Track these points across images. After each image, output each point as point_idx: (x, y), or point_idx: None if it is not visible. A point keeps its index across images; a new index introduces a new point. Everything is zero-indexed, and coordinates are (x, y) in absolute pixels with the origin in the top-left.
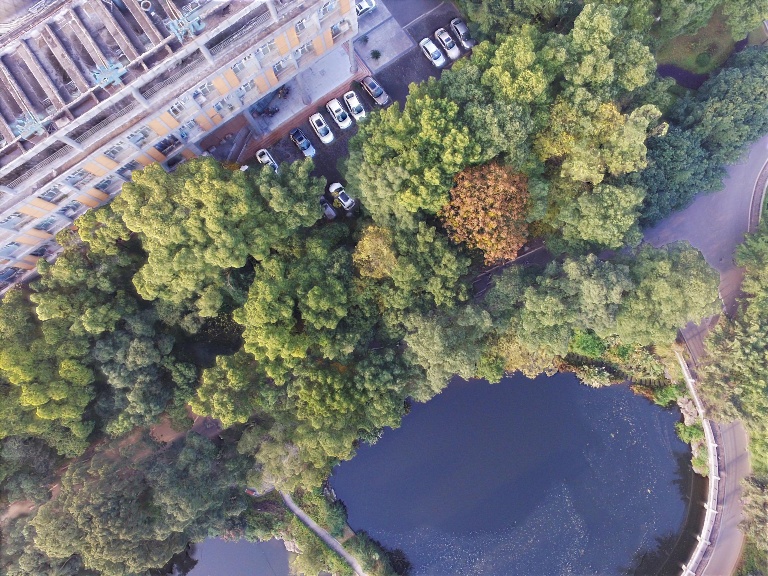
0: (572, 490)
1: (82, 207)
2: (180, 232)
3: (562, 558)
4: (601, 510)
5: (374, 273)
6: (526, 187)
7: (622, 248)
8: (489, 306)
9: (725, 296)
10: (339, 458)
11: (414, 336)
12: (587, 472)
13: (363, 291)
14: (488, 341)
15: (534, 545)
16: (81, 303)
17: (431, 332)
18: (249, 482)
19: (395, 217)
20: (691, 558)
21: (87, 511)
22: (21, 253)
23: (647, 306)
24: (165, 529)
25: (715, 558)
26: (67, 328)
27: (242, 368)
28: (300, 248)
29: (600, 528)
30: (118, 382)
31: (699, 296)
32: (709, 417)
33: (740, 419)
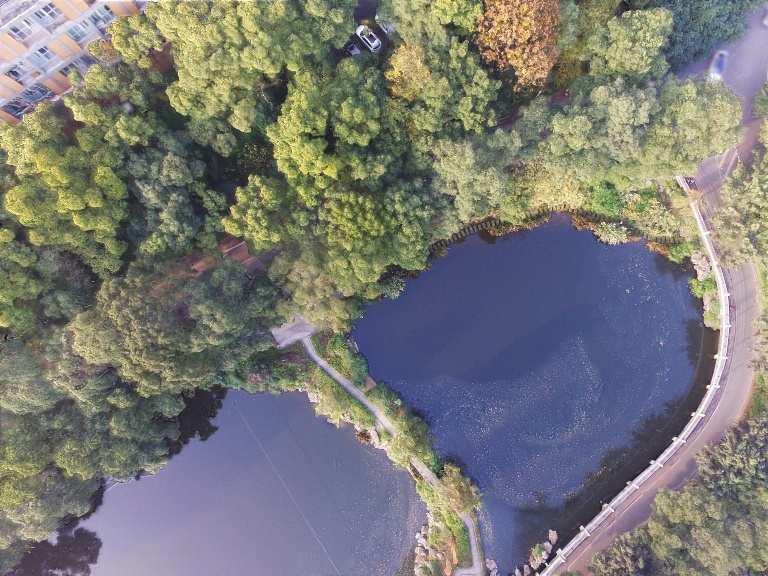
0: (588, 343)
1: (113, 20)
2: (216, 30)
3: (577, 407)
4: (615, 362)
5: (406, 90)
6: (558, 6)
7: (648, 80)
8: None
9: (741, 153)
10: (365, 297)
11: (444, 159)
12: (602, 326)
13: None
14: (514, 173)
15: (550, 395)
16: (114, 116)
17: (462, 149)
18: (280, 309)
19: (427, 36)
20: (700, 403)
21: (126, 313)
22: (51, 67)
23: (671, 134)
24: (201, 339)
25: (723, 403)
26: (101, 139)
27: None
28: (330, 77)
29: (614, 378)
30: (153, 195)
31: (724, 116)
32: (723, 264)
33: (755, 258)
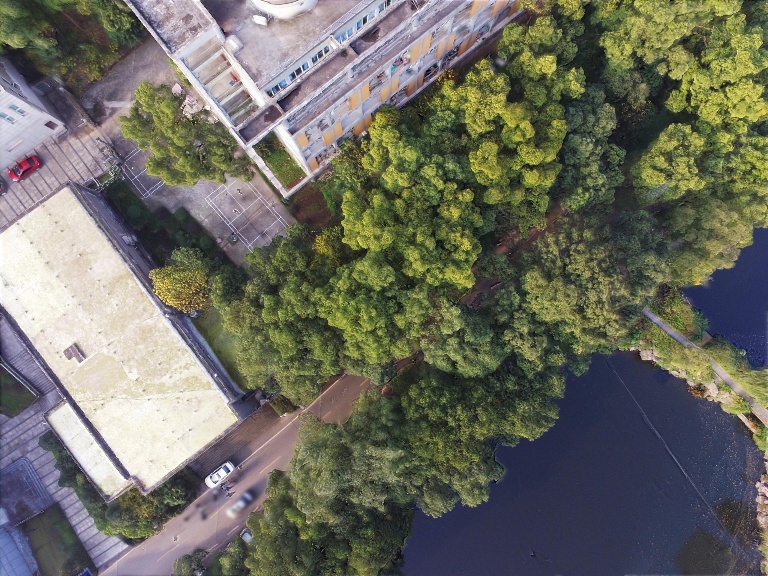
0: None
1: None
2: None
3: None
4: None
5: None
6: None
7: None
8: None
9: None
10: (735, 246)
11: None
12: None
13: None
14: None
15: None
16: None
17: None
18: (680, 260)
19: None
20: None
21: (592, 265)
22: (479, 25)
23: None
24: None
25: None
26: None
27: None
28: None
29: None
30: (592, 147)
31: None
32: None
33: None
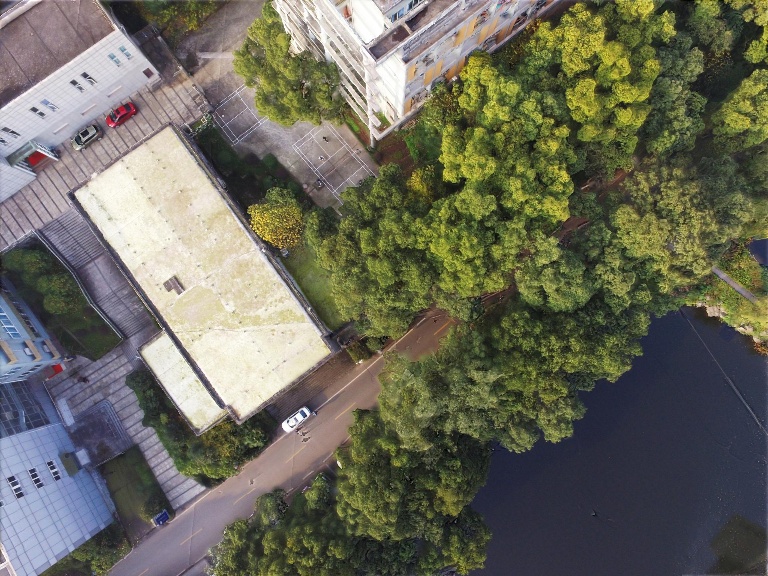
0: None
1: None
2: None
3: None
4: None
5: None
6: None
7: None
8: None
9: None
10: None
11: None
12: None
13: None
14: None
15: None
16: None
17: None
18: (760, 206)
19: None
20: None
21: (685, 200)
22: None
23: None
24: None
25: None
26: None
27: None
28: None
29: None
30: (681, 89)
31: None
32: None
33: None
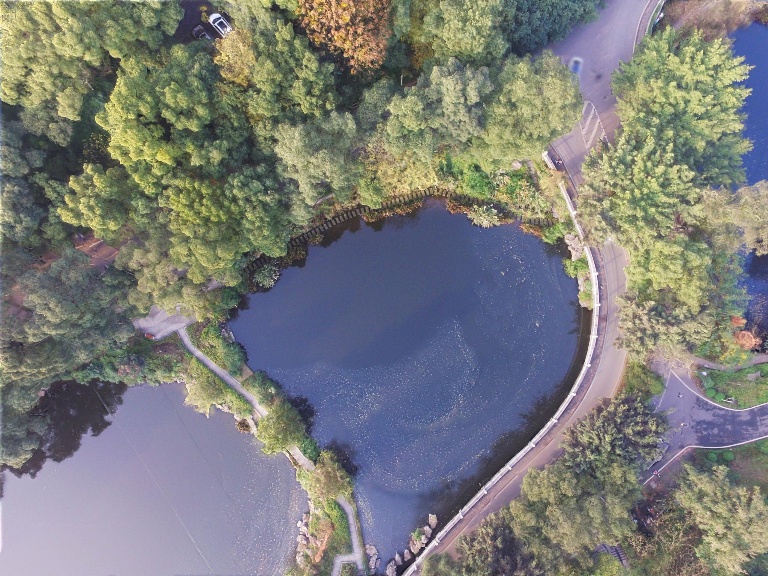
0: (464, 326)
1: None
2: (26, 18)
3: (454, 390)
4: (491, 344)
5: (235, 74)
6: None
7: (489, 59)
8: (360, 120)
9: (609, 133)
10: (225, 284)
11: None
12: (478, 309)
13: (227, 96)
14: (360, 156)
15: (427, 379)
16: None
17: (293, 132)
18: (128, 298)
19: (256, 20)
20: (574, 383)
21: None
22: None
23: (511, 113)
24: (35, 329)
25: (597, 382)
26: None
27: (111, 177)
28: None
29: (490, 361)
30: None
31: (554, 93)
32: (588, 243)
33: (611, 235)
